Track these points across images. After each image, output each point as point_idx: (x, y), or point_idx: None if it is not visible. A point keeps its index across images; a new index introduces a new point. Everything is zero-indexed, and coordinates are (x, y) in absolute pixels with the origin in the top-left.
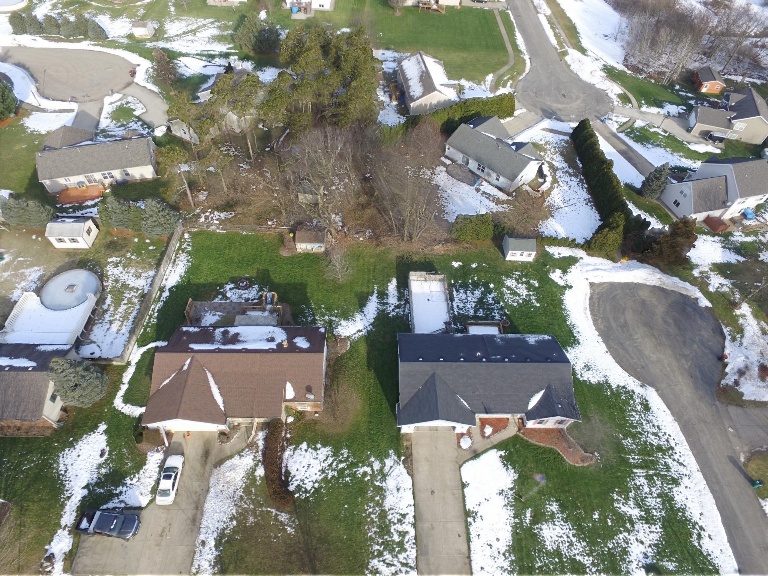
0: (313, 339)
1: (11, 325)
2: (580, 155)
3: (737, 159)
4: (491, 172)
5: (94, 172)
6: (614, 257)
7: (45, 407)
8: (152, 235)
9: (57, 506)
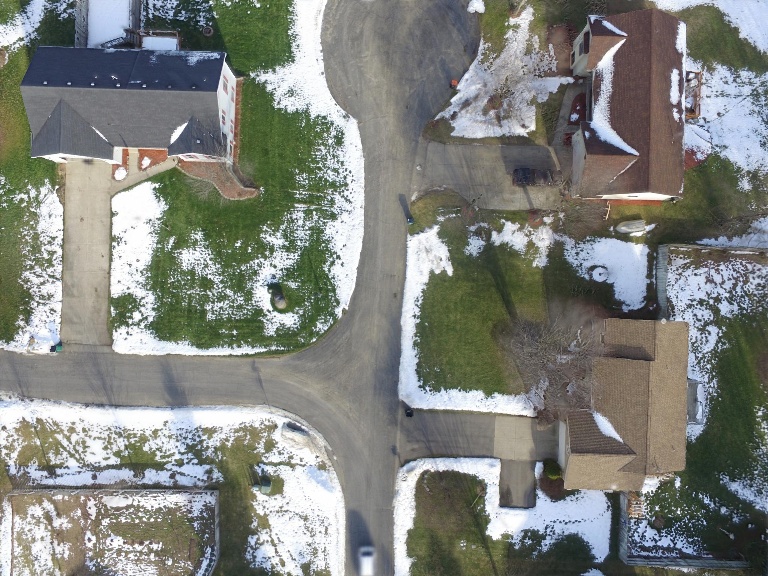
0: None
1: None
2: None
3: None
4: None
5: None
6: None
7: None
8: None
9: None
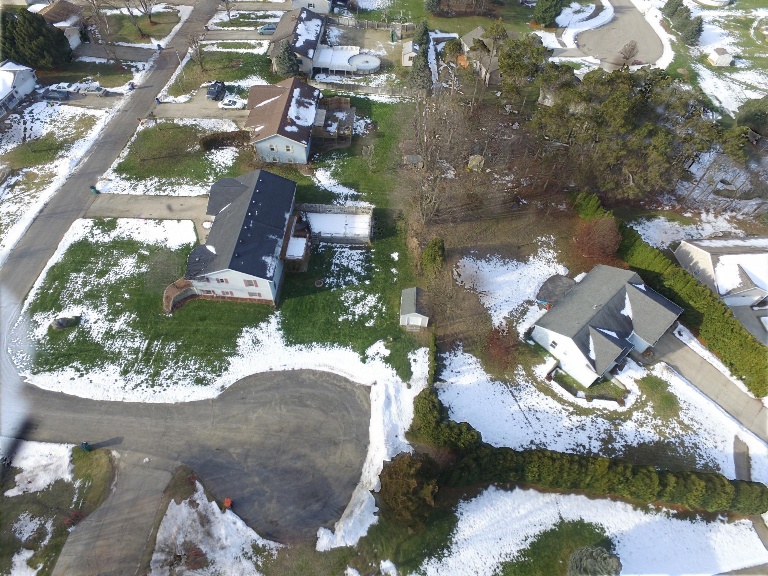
0: (293, 134)
1: (339, 49)
2: None
3: None
4: None
5: None
6: (417, 438)
7: None
8: None
9: (233, 80)
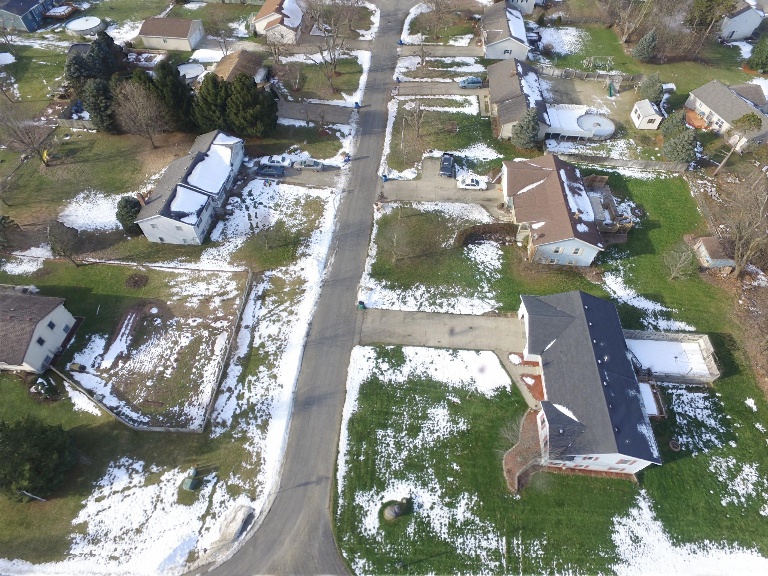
0: (587, 235)
1: (561, 108)
2: None
3: None
4: None
5: (717, 113)
6: None
7: (508, 124)
8: (663, 150)
9: (456, 148)
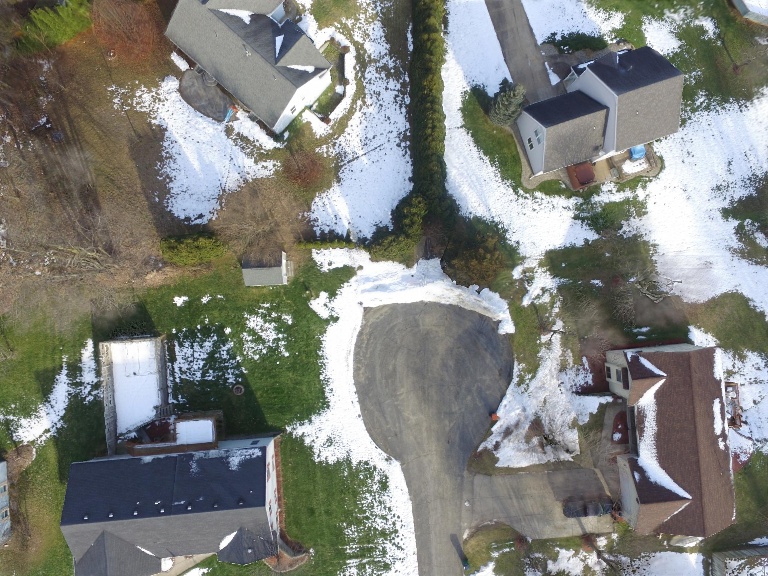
0: None
1: None
2: (413, 23)
3: (641, 67)
4: (241, 103)
5: None
6: (410, 256)
7: None
8: None
9: None
